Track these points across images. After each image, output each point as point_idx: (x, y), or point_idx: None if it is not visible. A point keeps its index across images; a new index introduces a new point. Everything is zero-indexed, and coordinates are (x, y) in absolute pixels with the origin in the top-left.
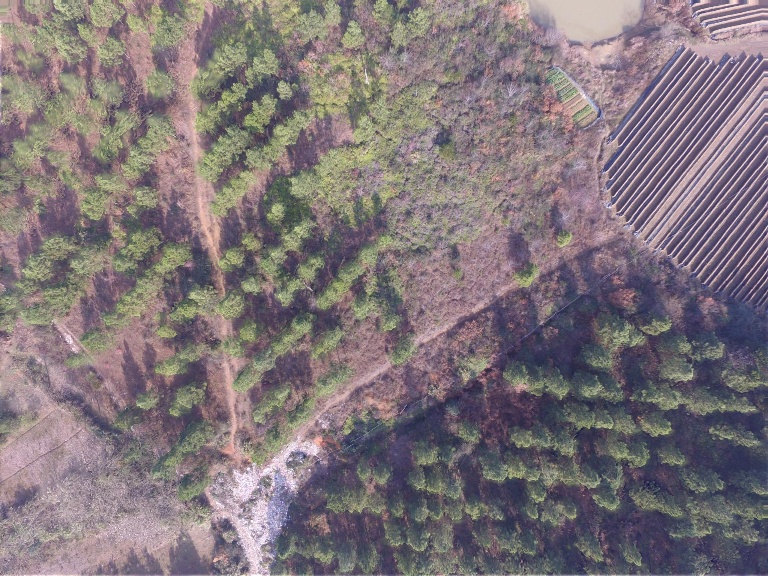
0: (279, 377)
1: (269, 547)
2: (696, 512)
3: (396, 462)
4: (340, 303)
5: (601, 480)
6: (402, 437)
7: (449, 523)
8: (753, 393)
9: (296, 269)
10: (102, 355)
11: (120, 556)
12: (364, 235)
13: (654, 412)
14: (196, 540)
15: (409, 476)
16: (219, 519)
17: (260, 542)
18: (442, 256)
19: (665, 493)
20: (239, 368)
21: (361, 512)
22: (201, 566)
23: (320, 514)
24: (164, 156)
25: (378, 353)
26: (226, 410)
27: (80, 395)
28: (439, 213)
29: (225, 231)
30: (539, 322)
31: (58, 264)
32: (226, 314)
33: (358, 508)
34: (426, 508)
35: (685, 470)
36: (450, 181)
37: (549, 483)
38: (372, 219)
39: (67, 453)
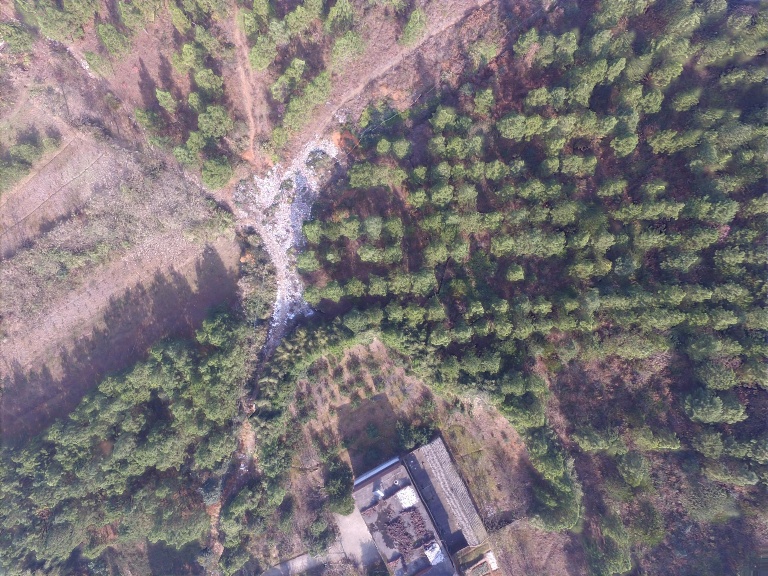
0: None
1: (294, 250)
2: (715, 137)
3: (414, 151)
4: None
5: (618, 122)
6: (419, 126)
7: (472, 183)
8: (760, 40)
9: None
10: (118, 76)
11: (147, 276)
12: None
13: (665, 59)
14: (222, 252)
15: (429, 143)
16: (243, 228)
17: (285, 246)
18: None
19: (682, 132)
20: (254, 71)
21: (383, 205)
22: (228, 278)
23: (343, 211)
24: None
25: (389, 43)
26: (244, 113)
27: (99, 120)
28: None
29: None
30: (544, 6)
31: None
32: None
33: (380, 178)
34: (448, 165)
35: (700, 110)
36: None
37: (567, 127)
38: None
39: (89, 180)
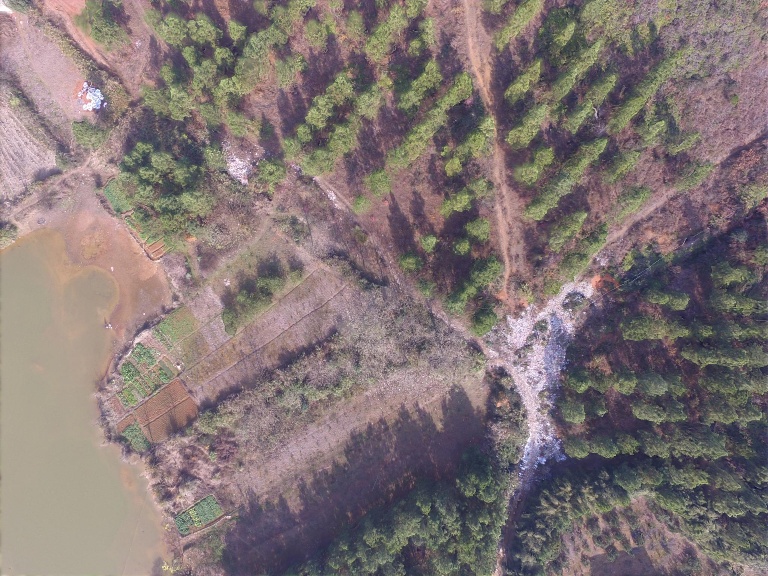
0: (555, 215)
1: (547, 393)
2: None
3: None
4: (618, 135)
5: None
6: (683, 271)
7: (758, 343)
8: None
9: (583, 95)
10: (367, 209)
11: (390, 412)
12: (640, 64)
13: None
14: (469, 391)
15: (711, 299)
16: (493, 368)
17: (537, 388)
18: (715, 85)
19: None
20: (511, 210)
21: (644, 351)
22: (475, 418)
23: (601, 355)
24: (431, 0)
25: (656, 185)
26: (501, 253)
27: (344, 252)
28: (711, 41)
29: (496, 70)
30: None
31: (335, 110)
32: (524, 137)
33: (659, 334)
34: None
35: None
36: (722, 7)
37: None
38: (647, 48)
39: (332, 311)
